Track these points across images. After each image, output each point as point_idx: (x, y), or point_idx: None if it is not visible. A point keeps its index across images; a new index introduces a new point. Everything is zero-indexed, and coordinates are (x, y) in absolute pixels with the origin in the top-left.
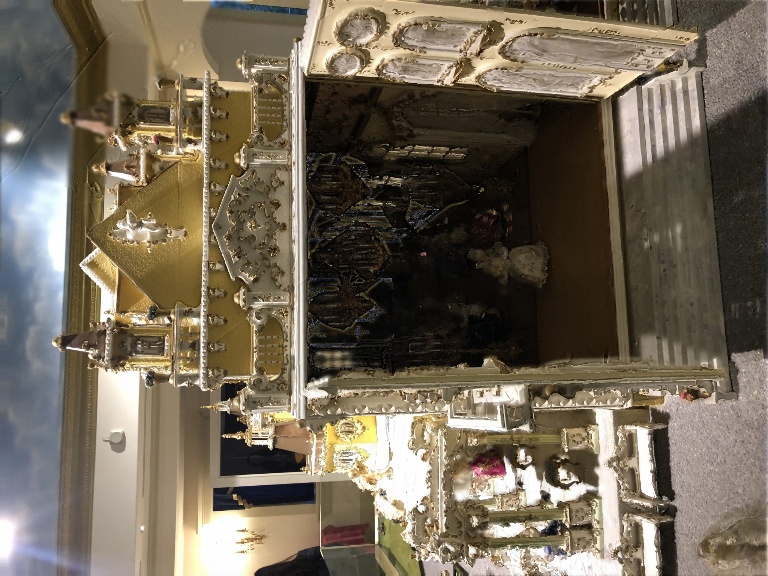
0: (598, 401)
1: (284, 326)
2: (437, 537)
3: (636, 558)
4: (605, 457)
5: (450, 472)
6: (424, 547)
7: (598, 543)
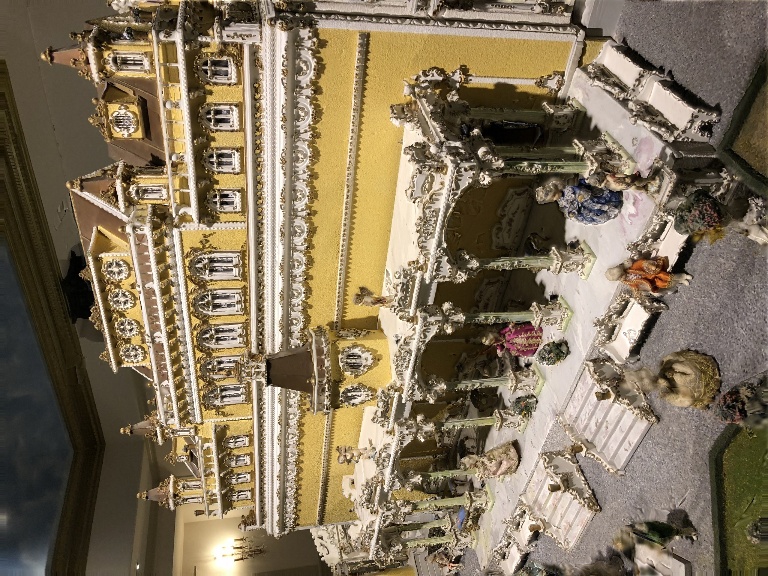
0: (550, 27)
1: (252, 5)
2: (437, 139)
3: (660, 122)
4: (591, 102)
5: (437, 113)
6: (429, 168)
7: (623, 155)
